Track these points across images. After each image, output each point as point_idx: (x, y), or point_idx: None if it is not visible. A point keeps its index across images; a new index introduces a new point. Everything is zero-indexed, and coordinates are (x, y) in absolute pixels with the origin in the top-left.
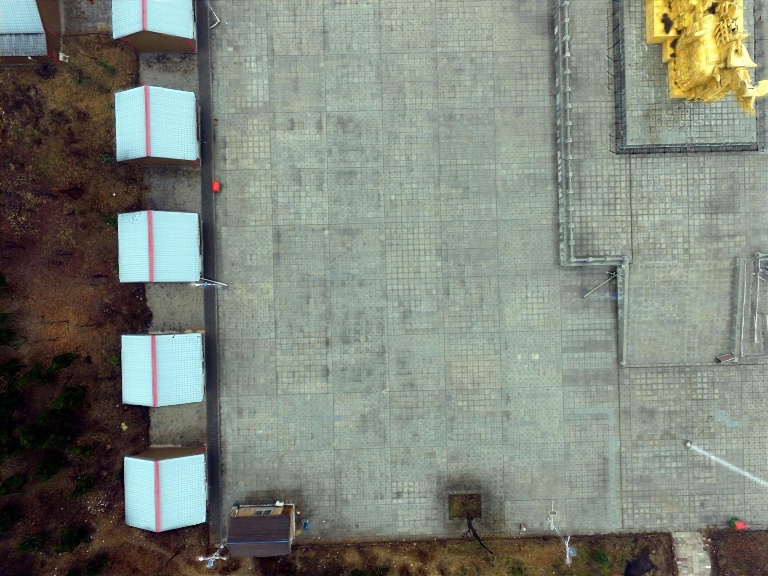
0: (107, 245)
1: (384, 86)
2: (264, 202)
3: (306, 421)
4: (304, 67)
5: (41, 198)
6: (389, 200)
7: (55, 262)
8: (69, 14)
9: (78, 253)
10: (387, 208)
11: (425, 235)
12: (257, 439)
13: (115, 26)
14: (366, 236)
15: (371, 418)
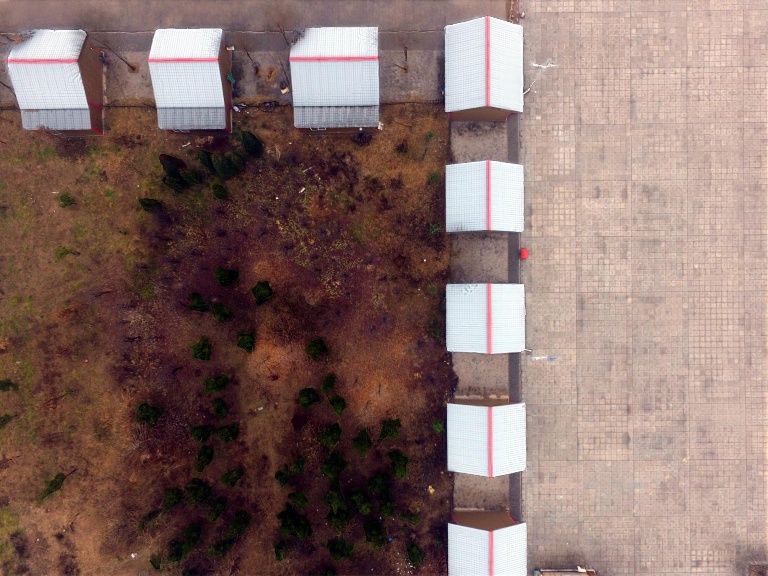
0: (418, 310)
1: (690, 155)
2: (568, 269)
3: (606, 487)
4: (611, 136)
5: (355, 263)
6: (693, 269)
7: (368, 326)
8: (384, 82)
9: (390, 318)
10: (690, 277)
11: (728, 304)
12: (558, 504)
13: (448, 99)
14: (669, 304)
15: (671, 486)
